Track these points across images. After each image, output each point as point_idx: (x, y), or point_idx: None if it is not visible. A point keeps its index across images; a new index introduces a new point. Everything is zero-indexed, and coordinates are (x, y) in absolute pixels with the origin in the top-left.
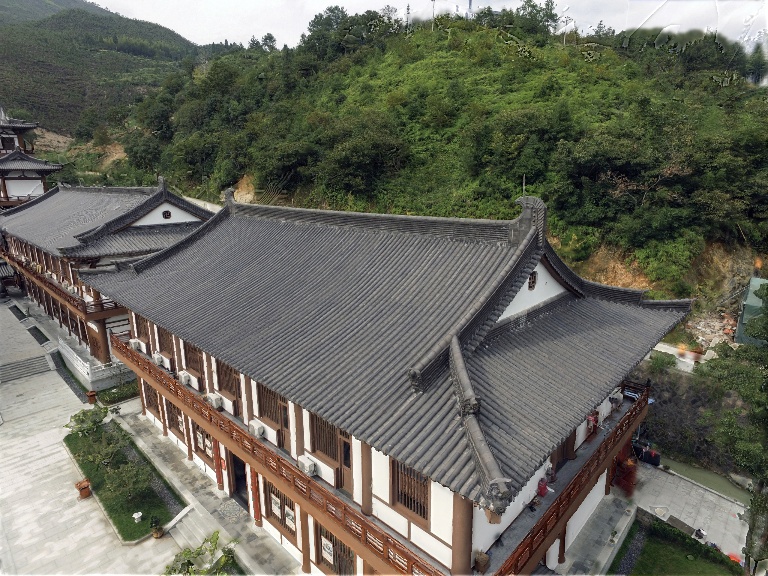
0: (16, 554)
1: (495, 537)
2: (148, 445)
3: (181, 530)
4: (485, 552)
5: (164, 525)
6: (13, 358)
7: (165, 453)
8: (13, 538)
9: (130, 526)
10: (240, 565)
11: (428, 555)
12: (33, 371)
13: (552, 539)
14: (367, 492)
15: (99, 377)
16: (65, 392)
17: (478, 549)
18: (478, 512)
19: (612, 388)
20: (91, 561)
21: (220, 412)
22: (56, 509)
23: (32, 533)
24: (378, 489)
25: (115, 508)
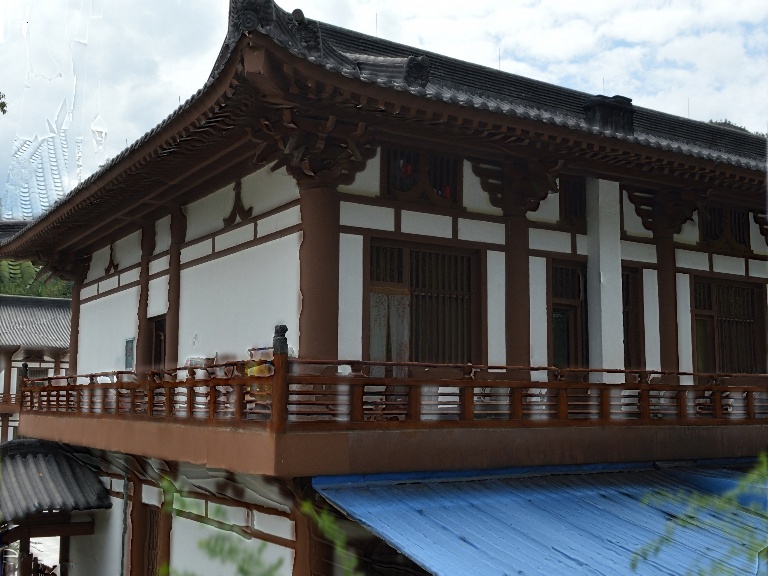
0: None
1: None
2: None
3: None
4: None
5: None
6: None
7: None
8: None
9: None
10: None
11: None
12: None
13: None
14: None
15: None
16: None
17: None
18: None
19: (55, 205)
20: None
21: None
22: None
23: None
24: None
25: None
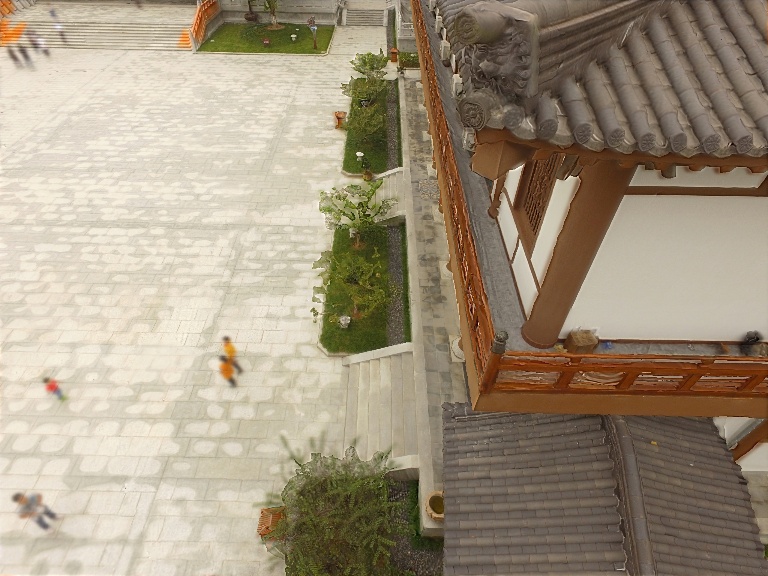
0: (281, 143)
1: (640, 334)
2: (407, 108)
3: (384, 183)
4: (603, 338)
5: (376, 173)
6: (362, 6)
7: (414, 120)
8: (285, 132)
9: (352, 161)
10: (406, 233)
11: (516, 290)
12: (370, 22)
13: (760, 410)
14: (500, 182)
15: (406, 37)
16: (381, 46)
17: (588, 323)
18: (613, 264)
19: None
20: (316, 171)
21: (445, 66)
22: (319, 127)
23: (297, 135)
24: (511, 181)
25: (352, 143)
